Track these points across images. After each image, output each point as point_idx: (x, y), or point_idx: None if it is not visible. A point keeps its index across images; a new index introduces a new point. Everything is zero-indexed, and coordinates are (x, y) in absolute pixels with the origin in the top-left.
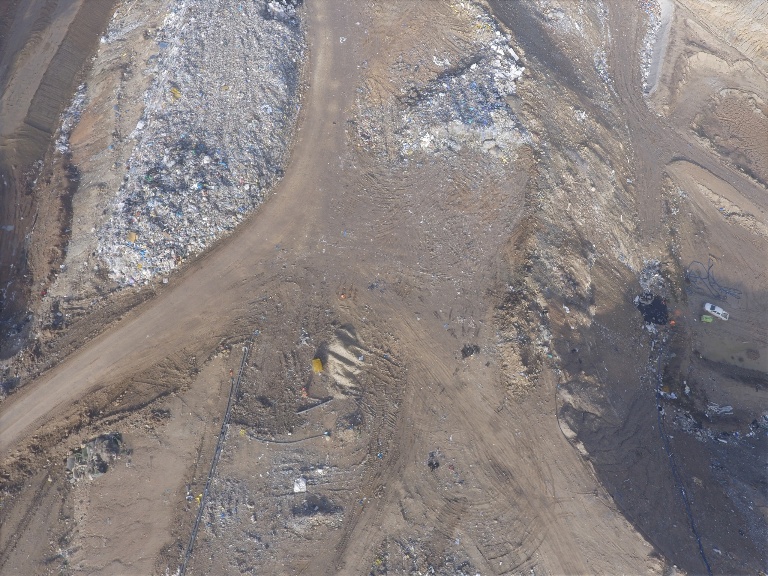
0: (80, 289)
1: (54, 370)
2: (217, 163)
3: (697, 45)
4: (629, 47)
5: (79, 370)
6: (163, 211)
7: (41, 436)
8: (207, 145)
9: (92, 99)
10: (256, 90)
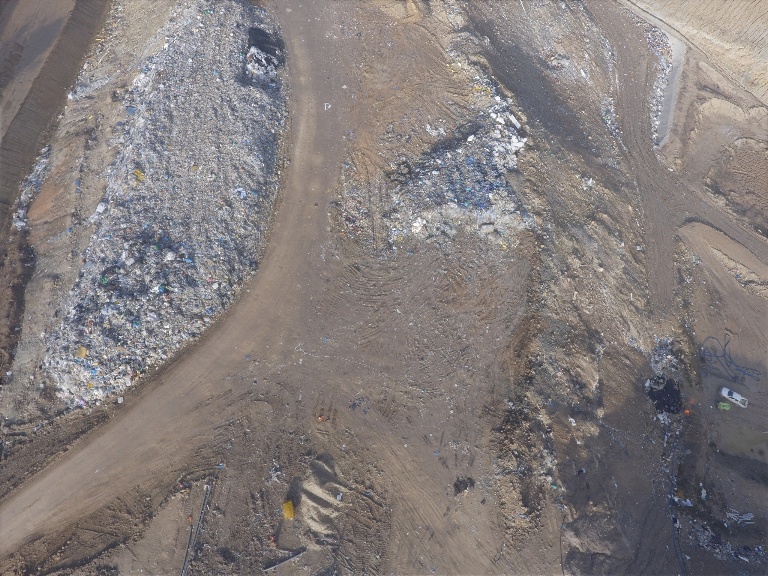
0: (23, 411)
1: None
2: (182, 259)
3: (710, 90)
4: (638, 94)
5: (16, 514)
6: (118, 320)
7: None
8: (172, 237)
9: (54, 166)
10: (229, 170)
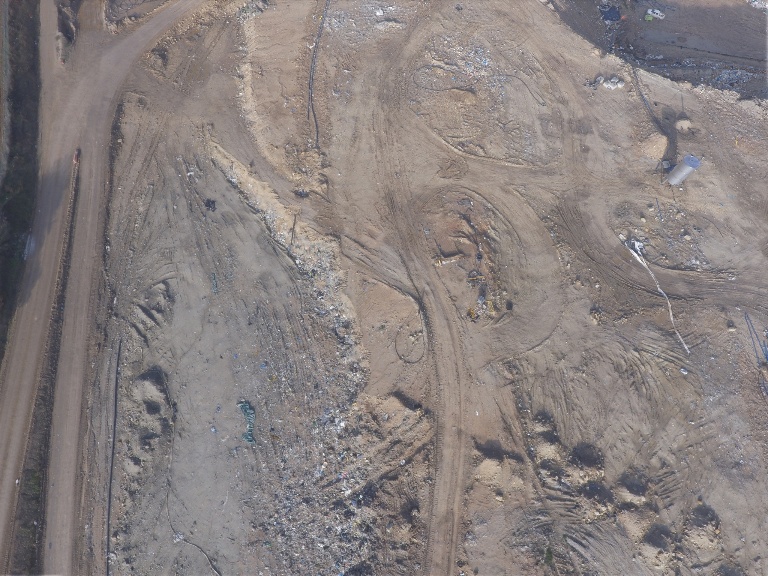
0: None
1: None
2: None
3: None
4: None
5: None
6: None
7: (219, 1)
8: None
9: None
10: None
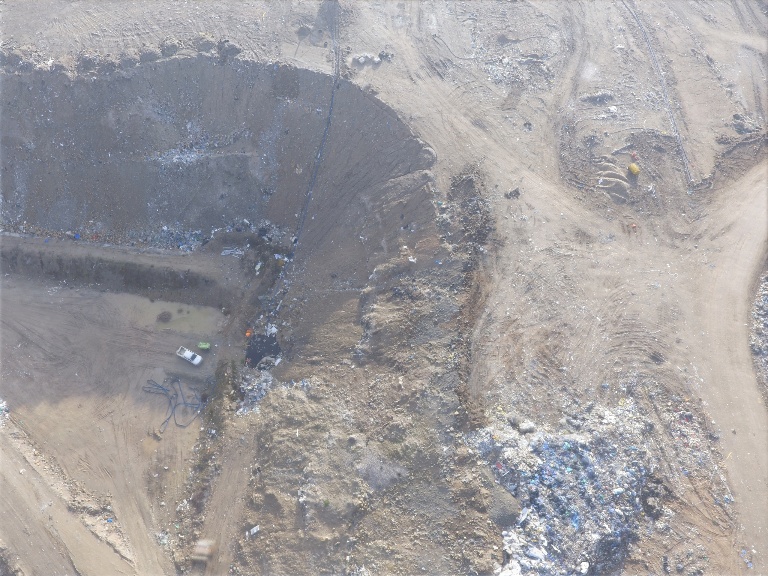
0: None
1: None
2: None
3: None
4: None
5: None
6: None
7: None
8: None
9: None
10: None
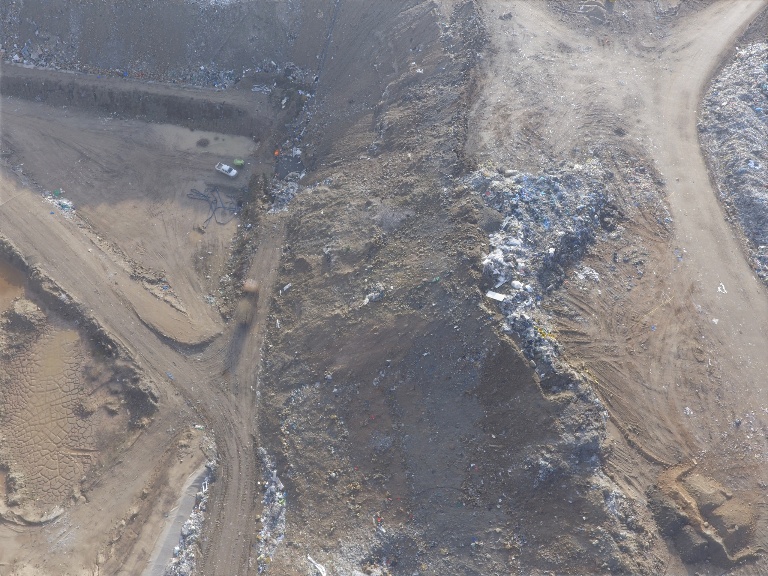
0: None
1: (767, 2)
2: (764, 109)
3: None
4: None
5: (753, 2)
6: None
7: None
8: None
9: None
10: None
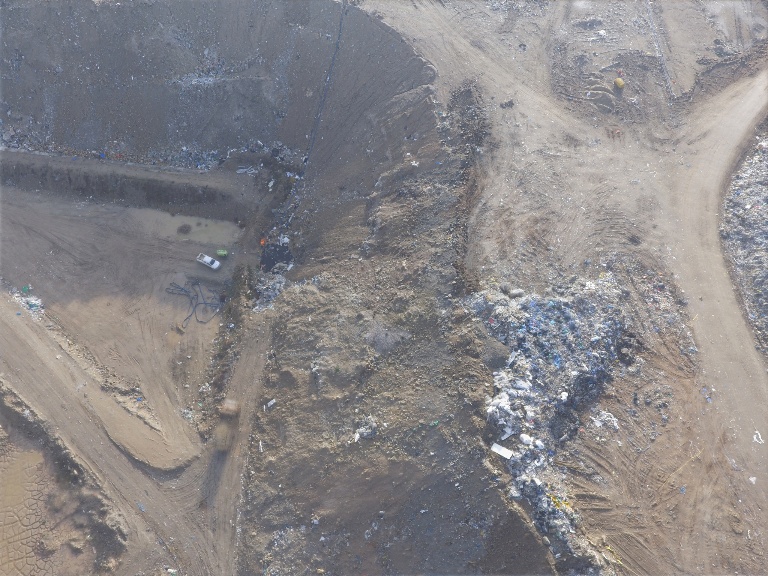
0: None
1: None
2: None
3: None
4: None
5: None
6: None
7: (763, 57)
8: None
9: None
10: None
